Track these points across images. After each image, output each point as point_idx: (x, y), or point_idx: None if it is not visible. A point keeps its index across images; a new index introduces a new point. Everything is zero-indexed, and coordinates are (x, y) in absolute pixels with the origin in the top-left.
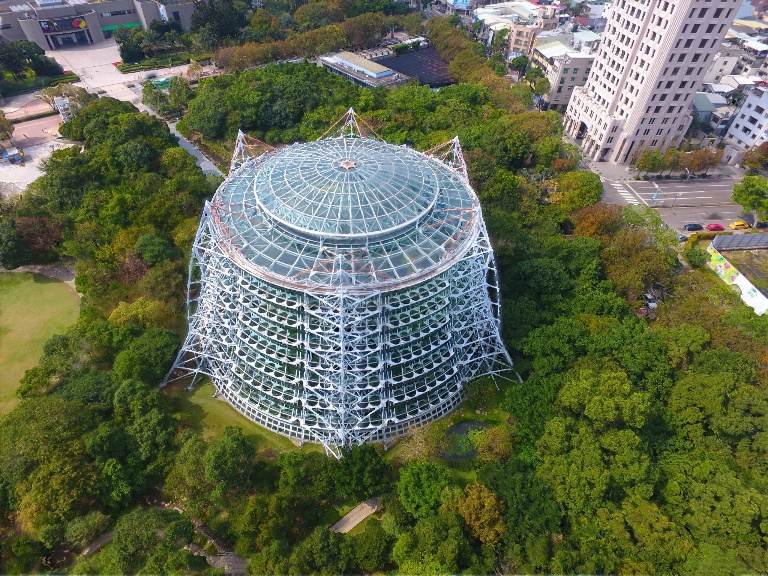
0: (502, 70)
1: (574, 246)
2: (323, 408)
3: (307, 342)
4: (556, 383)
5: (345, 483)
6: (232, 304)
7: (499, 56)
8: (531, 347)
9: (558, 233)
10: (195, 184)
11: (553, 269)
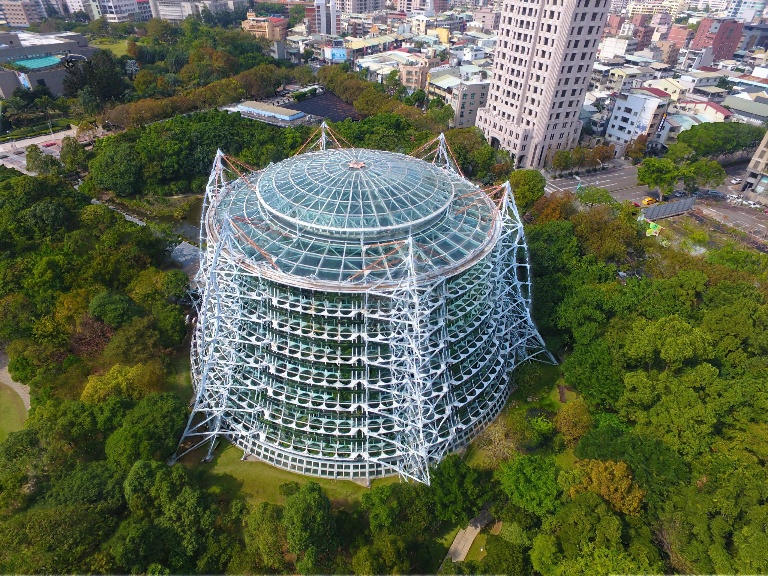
0: (409, 101)
1: (550, 230)
2: (389, 431)
3: (364, 356)
4: (605, 346)
5: (449, 504)
6: (257, 337)
7: (404, 89)
8: (565, 320)
9: (524, 225)
10: (138, 235)
11: (548, 250)
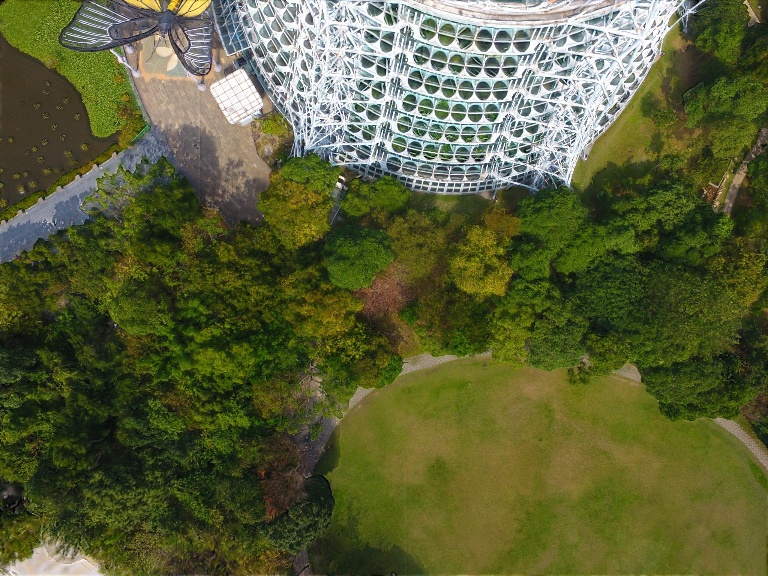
0: None
1: None
2: None
3: None
4: None
5: None
6: None
7: None
8: None
9: None
10: (146, 221)
11: None
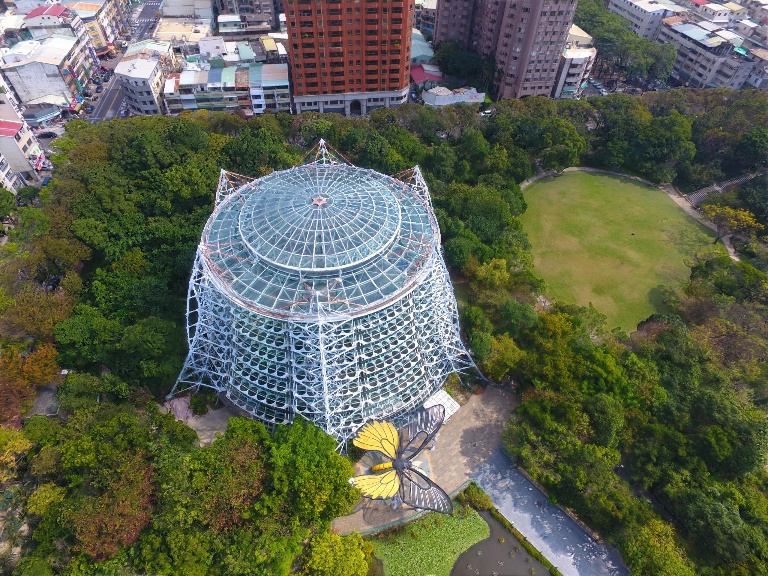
0: None
1: None
2: None
3: None
4: (197, 216)
5: None
6: None
7: None
8: None
9: None
10: None
11: None
